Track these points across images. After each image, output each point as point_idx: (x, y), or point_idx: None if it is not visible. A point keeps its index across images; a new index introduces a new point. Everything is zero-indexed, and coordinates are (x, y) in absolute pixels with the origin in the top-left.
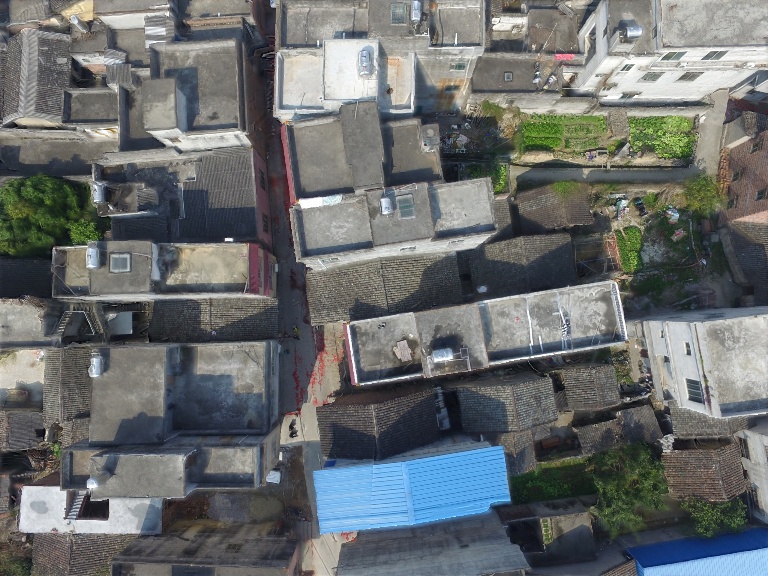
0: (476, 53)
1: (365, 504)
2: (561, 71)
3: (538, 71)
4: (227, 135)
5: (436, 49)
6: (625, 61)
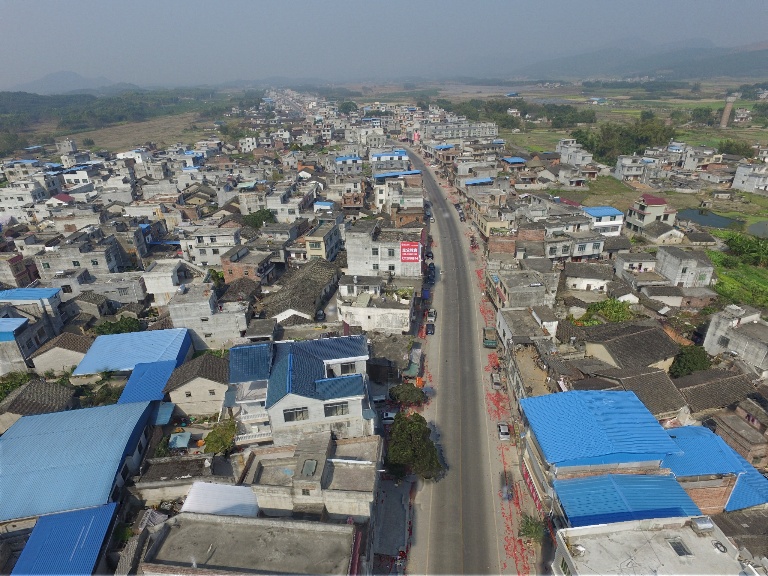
0: (132, 234)
1: None
2: (177, 254)
3: (168, 254)
4: (40, 247)
5: (119, 233)
6: (187, 243)
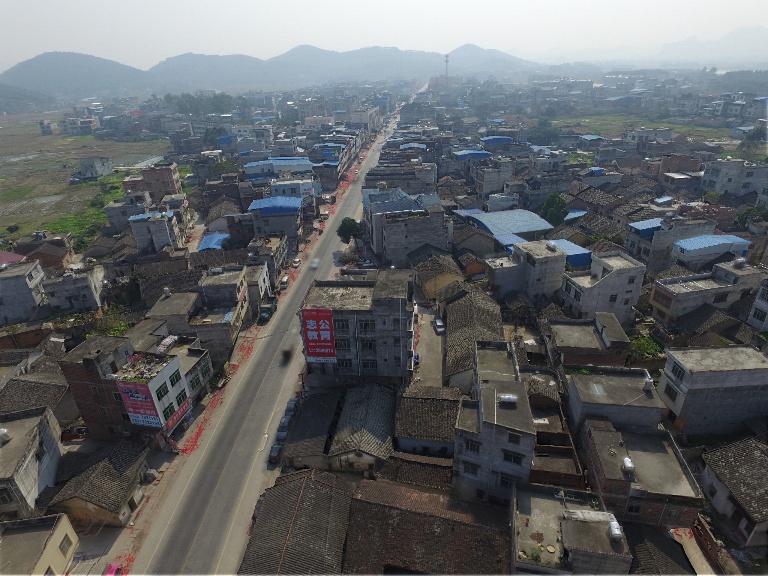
0: None
1: (726, 238)
2: None
3: None
4: None
5: None
6: None
